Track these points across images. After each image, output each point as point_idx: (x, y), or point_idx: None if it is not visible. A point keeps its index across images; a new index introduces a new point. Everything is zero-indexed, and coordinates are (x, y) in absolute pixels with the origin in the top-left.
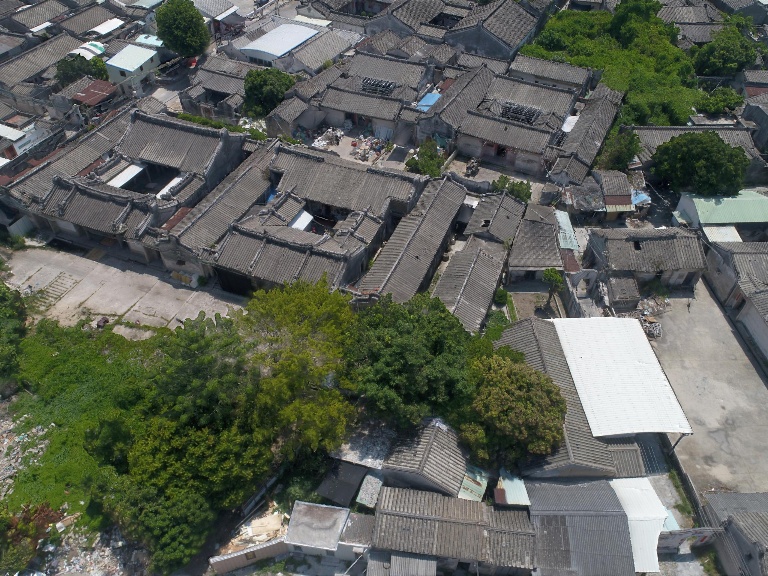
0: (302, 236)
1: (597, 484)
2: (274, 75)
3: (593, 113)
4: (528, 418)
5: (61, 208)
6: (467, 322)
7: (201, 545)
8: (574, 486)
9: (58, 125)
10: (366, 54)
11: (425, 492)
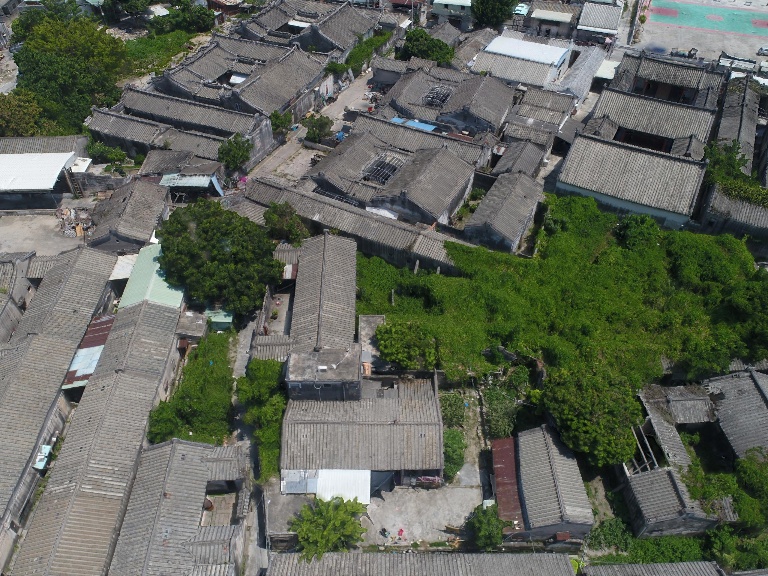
0: (209, 71)
1: None
2: (436, 46)
3: None
4: None
5: (260, 8)
6: (96, 122)
7: None
8: None
9: (372, 2)
10: None
11: None
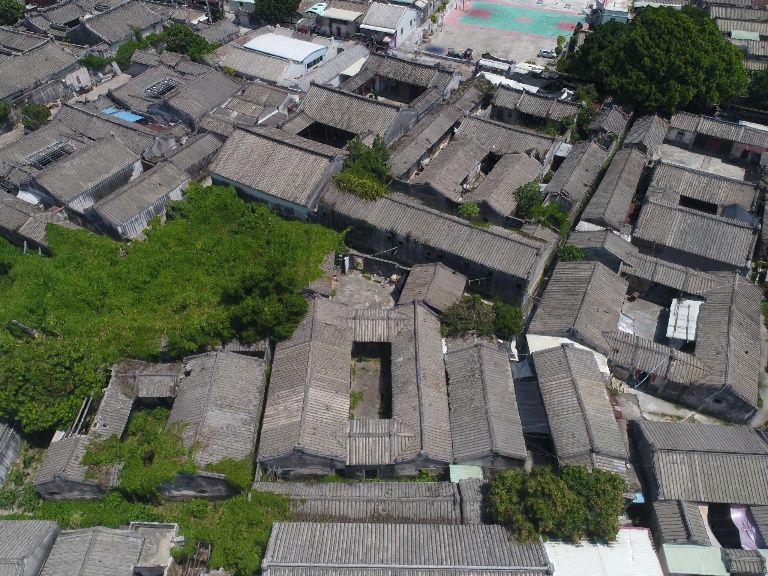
0: None
1: None
2: (194, 42)
3: (7, 201)
4: None
5: None
6: None
7: None
8: None
9: None
10: (209, 73)
11: None
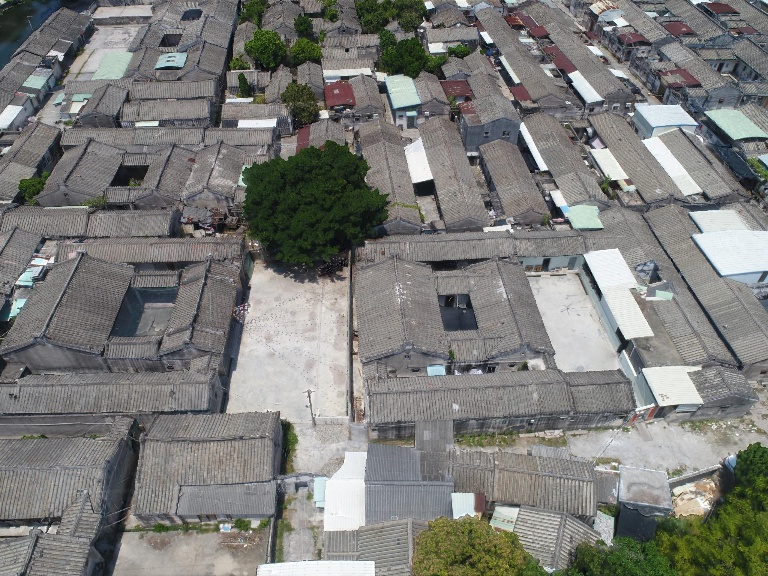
0: None
1: (380, 519)
2: None
3: None
4: (469, 519)
5: None
6: None
7: (736, 467)
8: (404, 517)
9: None
10: None
11: (552, 509)
